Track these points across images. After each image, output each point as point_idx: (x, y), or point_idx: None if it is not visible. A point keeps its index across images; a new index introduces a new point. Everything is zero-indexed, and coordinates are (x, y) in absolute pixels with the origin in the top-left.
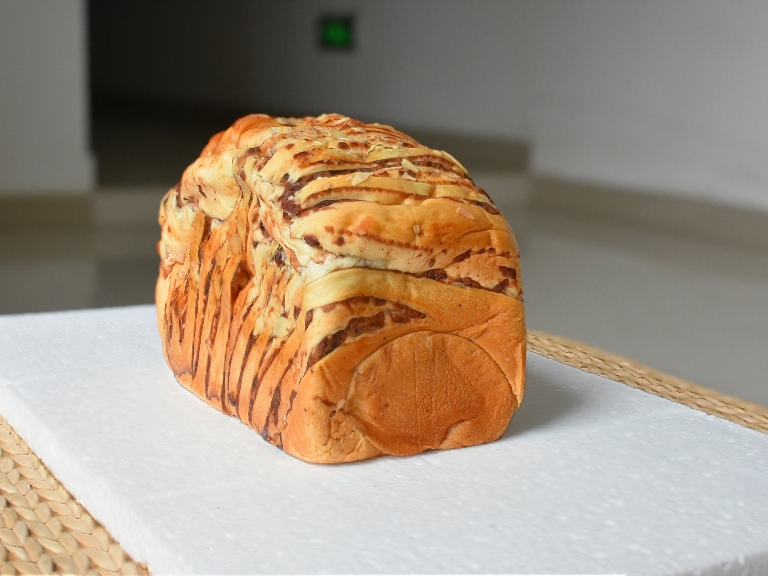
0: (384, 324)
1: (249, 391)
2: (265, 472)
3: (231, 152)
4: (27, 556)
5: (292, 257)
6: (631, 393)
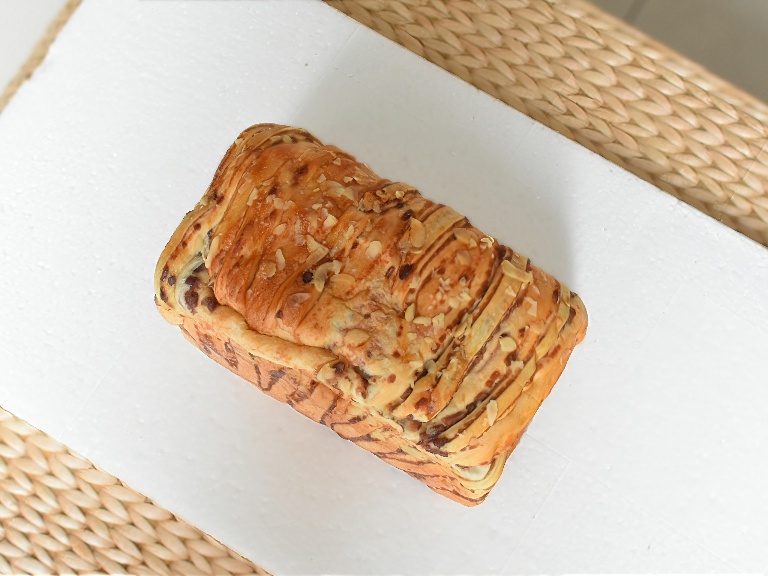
0: None
1: None
2: (441, 531)
3: (305, 361)
4: None
5: None
6: (598, 173)
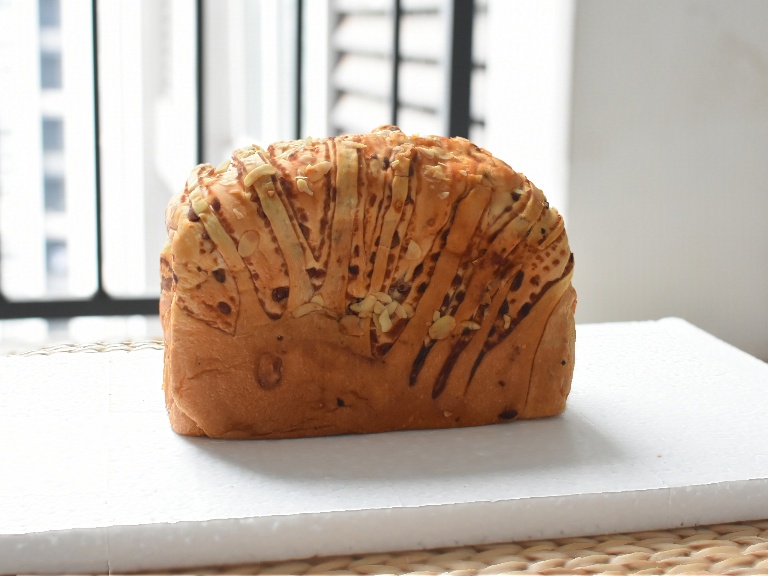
0: None
1: None
2: None
3: None
4: None
5: None
6: (289, 505)
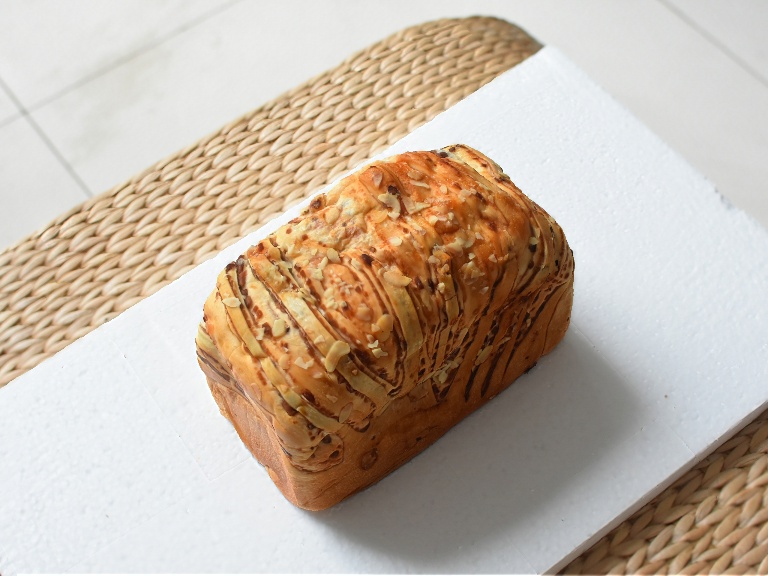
0: (230, 382)
1: None
2: None
3: (334, 187)
4: (134, 275)
5: None
6: None
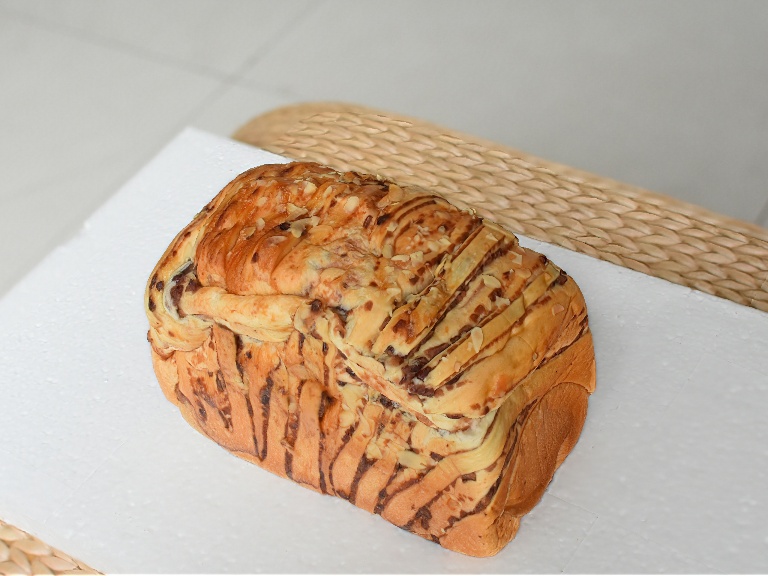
0: (518, 435)
1: (374, 498)
2: None
3: (281, 306)
4: None
5: (421, 418)
6: (607, 274)
